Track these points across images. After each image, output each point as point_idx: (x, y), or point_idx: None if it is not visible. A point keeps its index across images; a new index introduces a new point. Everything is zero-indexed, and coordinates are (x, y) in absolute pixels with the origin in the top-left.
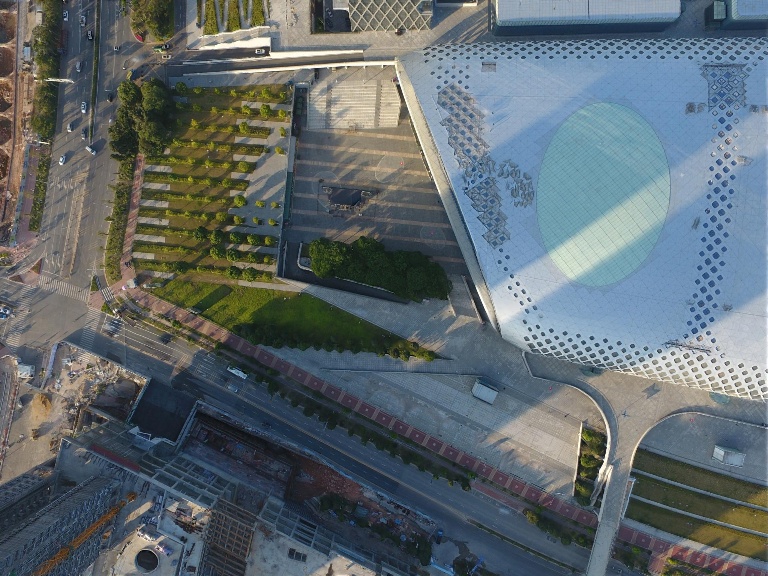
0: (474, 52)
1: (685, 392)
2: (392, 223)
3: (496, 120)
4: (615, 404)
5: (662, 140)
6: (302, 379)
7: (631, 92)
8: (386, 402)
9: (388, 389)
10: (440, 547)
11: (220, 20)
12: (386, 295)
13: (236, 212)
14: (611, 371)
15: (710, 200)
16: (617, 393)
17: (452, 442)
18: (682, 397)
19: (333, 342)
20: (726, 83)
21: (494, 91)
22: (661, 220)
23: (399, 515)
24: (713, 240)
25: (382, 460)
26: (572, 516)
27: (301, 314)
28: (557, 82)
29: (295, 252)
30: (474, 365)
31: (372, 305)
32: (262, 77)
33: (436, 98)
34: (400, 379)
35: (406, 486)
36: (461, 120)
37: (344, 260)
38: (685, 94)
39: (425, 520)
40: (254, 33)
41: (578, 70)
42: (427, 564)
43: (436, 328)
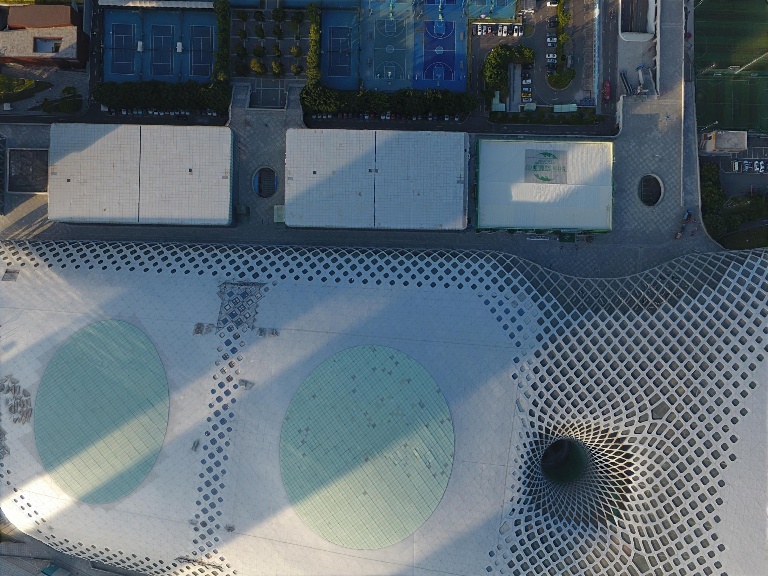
0: (5, 256)
1: None
2: None
3: (3, 333)
4: None
5: (164, 362)
6: None
7: (142, 310)
8: None
9: None
10: None
11: None
12: None
13: None
14: None
15: (210, 423)
16: None
17: None
18: None
19: None
20: (240, 303)
21: (7, 302)
22: (158, 442)
23: None
24: (213, 462)
25: None
26: None
27: None
28: (72, 296)
29: None
30: (48, 548)
31: None
32: None
33: None
34: None
35: None
36: None
37: None
38: (196, 314)
39: None
40: None
41: (96, 283)
42: None
43: None
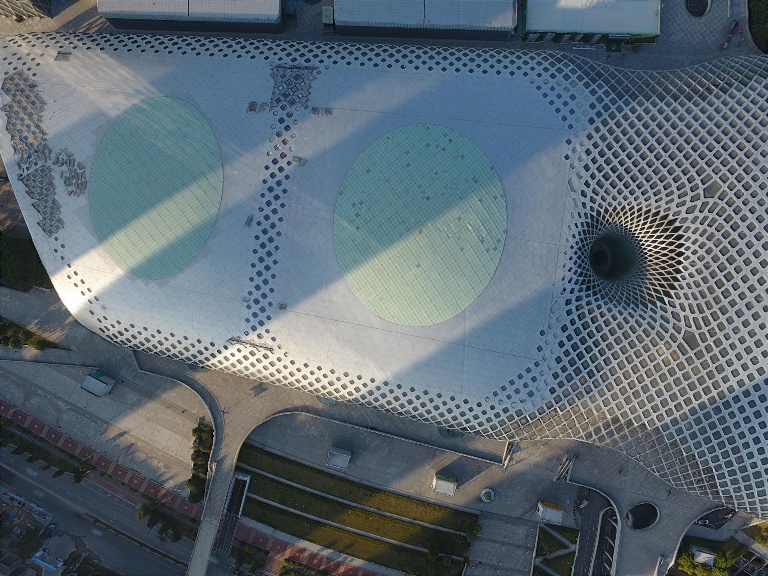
0: (56, 41)
1: (292, 392)
2: None
3: (57, 108)
4: (222, 401)
5: (218, 137)
6: None
7: (195, 88)
8: (5, 391)
9: (8, 378)
10: (56, 541)
11: None
12: None
13: None
14: None
15: (264, 198)
16: (224, 390)
17: (71, 434)
18: (289, 396)
19: None
20: (293, 85)
21: (60, 80)
22: (212, 216)
23: (15, 507)
24: (266, 238)
25: None
26: (190, 513)
27: None
28: (125, 74)
29: None
30: (93, 357)
31: None
32: None
33: (1, 84)
34: (19, 368)
35: (23, 477)
36: (22, 107)
37: None
38: (249, 93)
39: (41, 513)
40: None
41: (149, 64)
42: (24, 557)
43: (56, 318)
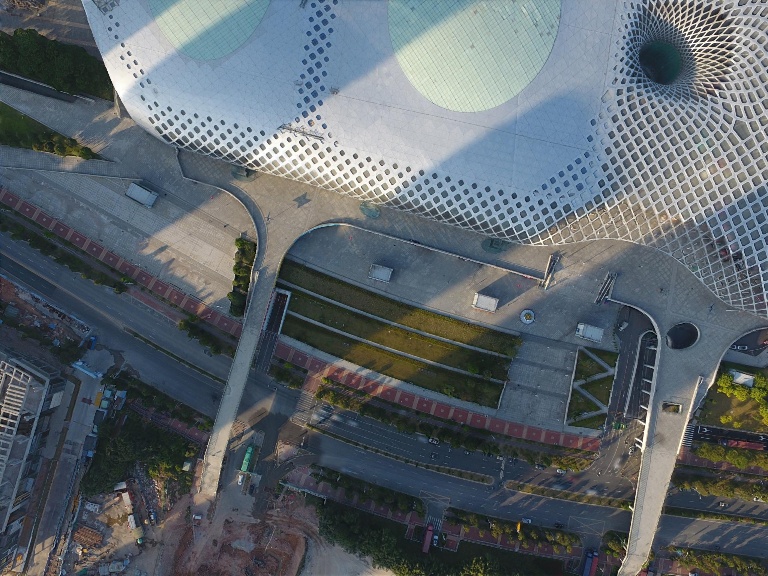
0: None
1: (336, 203)
2: (71, 26)
3: None
4: (266, 211)
5: None
6: None
7: None
8: (48, 203)
9: (51, 190)
10: (95, 355)
11: None
12: (52, 93)
13: None
14: (264, 177)
15: None
16: (268, 200)
17: (113, 248)
18: (333, 208)
19: None
20: None
21: None
22: None
23: (54, 319)
24: (320, 21)
25: (41, 262)
26: (230, 330)
27: None
28: None
29: None
30: (137, 169)
31: (36, 102)
32: None
33: None
34: (62, 179)
35: (63, 290)
36: None
37: None
38: None
39: (81, 326)
40: None
41: None
42: (64, 361)
43: (100, 129)
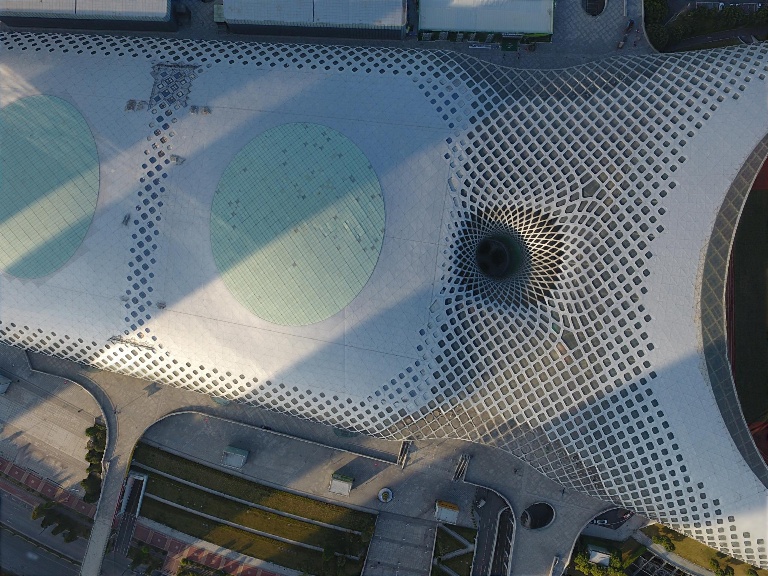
0: None
1: (186, 391)
2: None
3: None
4: (115, 400)
5: (95, 135)
6: None
7: (74, 86)
8: None
9: None
10: None
11: None
12: None
13: None
14: None
15: (141, 197)
16: (118, 389)
17: None
18: (183, 396)
19: None
20: (173, 83)
21: None
22: (89, 215)
23: None
24: (144, 237)
25: None
26: (88, 513)
27: None
28: (4, 72)
29: None
30: None
31: None
32: None
33: None
34: None
35: None
36: None
37: None
38: (128, 91)
39: None
40: None
41: (29, 62)
42: None
43: None
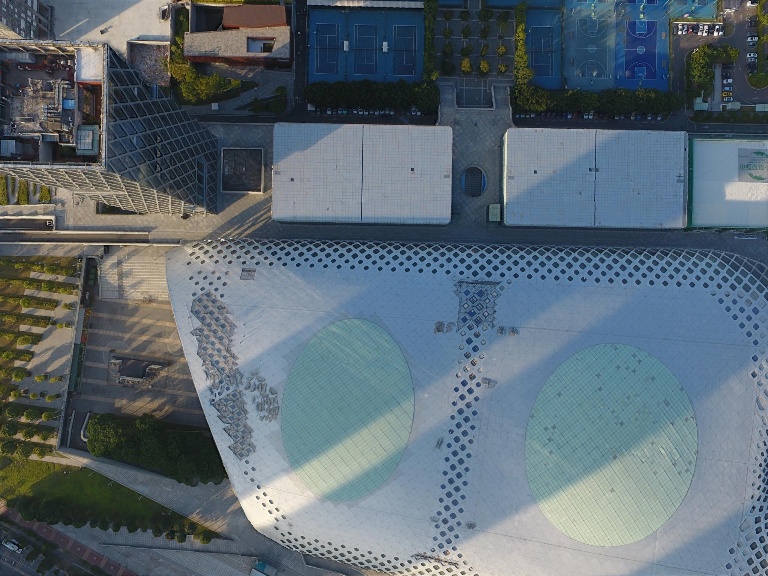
0: (238, 255)
1: None
2: (182, 395)
3: (247, 332)
4: None
5: (408, 360)
6: (81, 553)
7: (383, 308)
8: None
9: (168, 566)
10: None
11: (11, 191)
12: None
13: (20, 383)
14: None
15: (454, 421)
16: None
17: None
18: None
19: (108, 522)
20: (477, 302)
21: (248, 301)
22: (404, 440)
23: None
24: (456, 460)
25: None
26: None
27: (81, 489)
28: (312, 294)
29: (81, 423)
30: (254, 546)
31: (153, 482)
32: (52, 249)
33: (190, 306)
34: (180, 557)
35: None
36: (212, 330)
37: (118, 442)
38: (436, 312)
39: None
40: (40, 210)
41: (334, 282)
42: None
43: (217, 507)
